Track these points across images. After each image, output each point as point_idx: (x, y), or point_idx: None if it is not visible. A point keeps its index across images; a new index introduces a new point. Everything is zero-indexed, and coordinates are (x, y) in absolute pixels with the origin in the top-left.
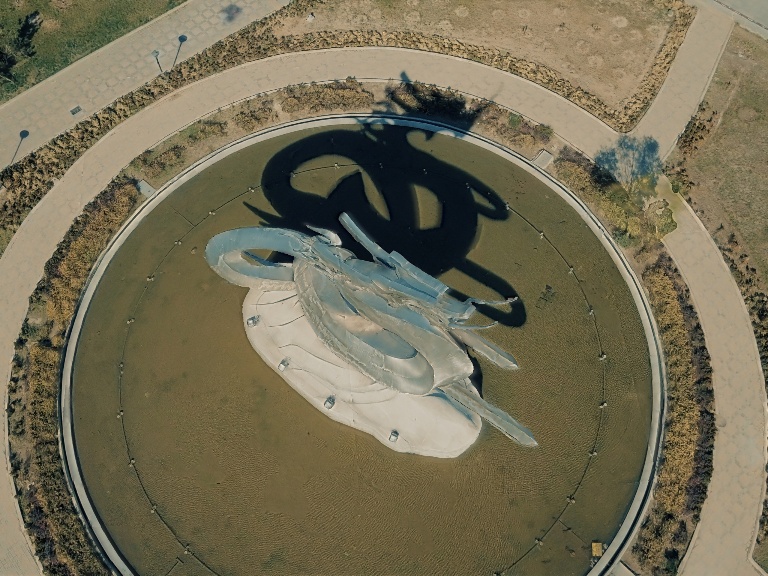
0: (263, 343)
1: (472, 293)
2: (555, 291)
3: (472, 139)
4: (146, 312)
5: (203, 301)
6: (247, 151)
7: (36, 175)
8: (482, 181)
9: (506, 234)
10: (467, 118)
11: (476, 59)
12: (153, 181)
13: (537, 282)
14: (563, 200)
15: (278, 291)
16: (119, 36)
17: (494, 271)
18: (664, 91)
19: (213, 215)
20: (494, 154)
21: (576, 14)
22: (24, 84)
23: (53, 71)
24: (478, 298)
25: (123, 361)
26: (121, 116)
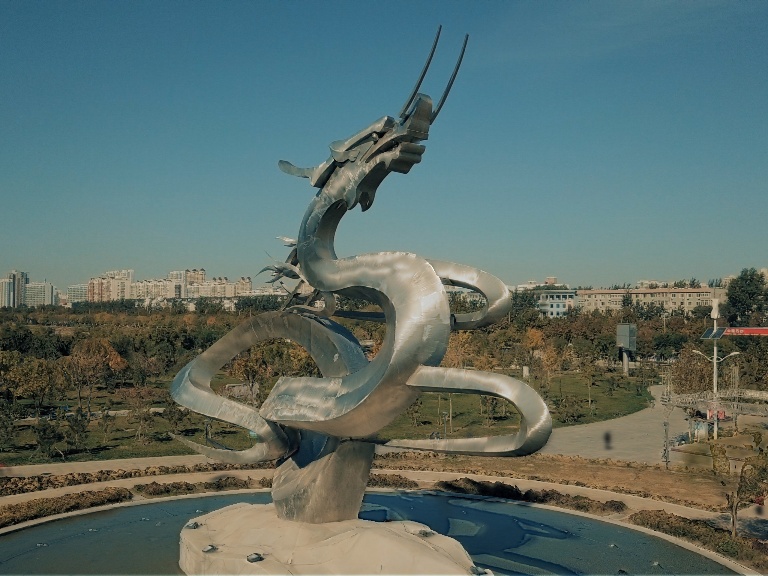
0: (196, 538)
1: (507, 567)
2: (632, 575)
3: (526, 503)
4: (67, 544)
5: (143, 545)
6: (264, 495)
7: (34, 483)
8: (534, 521)
9: (562, 544)
10: (522, 497)
11: (538, 478)
12: (150, 497)
13: (605, 569)
14: (642, 533)
15: (241, 507)
16: (181, 455)
17: (542, 559)
18: (767, 503)
19: (200, 513)
20: (552, 511)
21: (653, 476)
22: (73, 461)
23: (105, 459)
24: (515, 570)
25: (3, 563)
26: (149, 472)
